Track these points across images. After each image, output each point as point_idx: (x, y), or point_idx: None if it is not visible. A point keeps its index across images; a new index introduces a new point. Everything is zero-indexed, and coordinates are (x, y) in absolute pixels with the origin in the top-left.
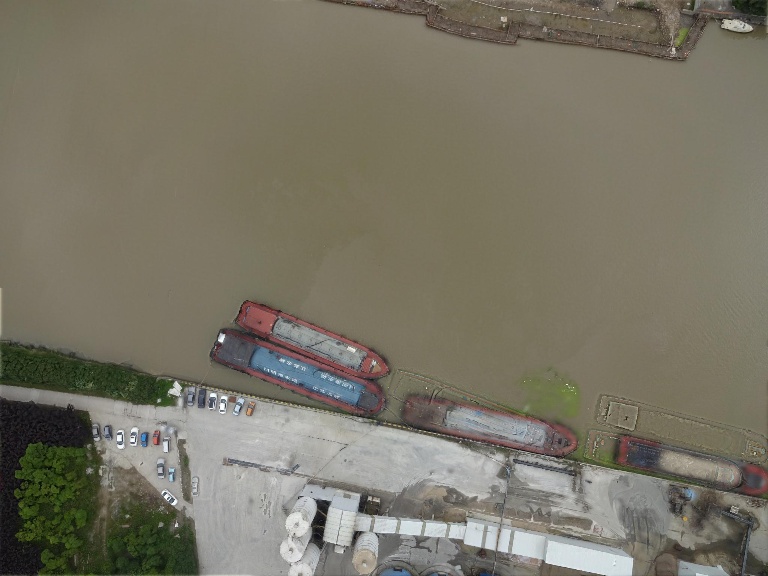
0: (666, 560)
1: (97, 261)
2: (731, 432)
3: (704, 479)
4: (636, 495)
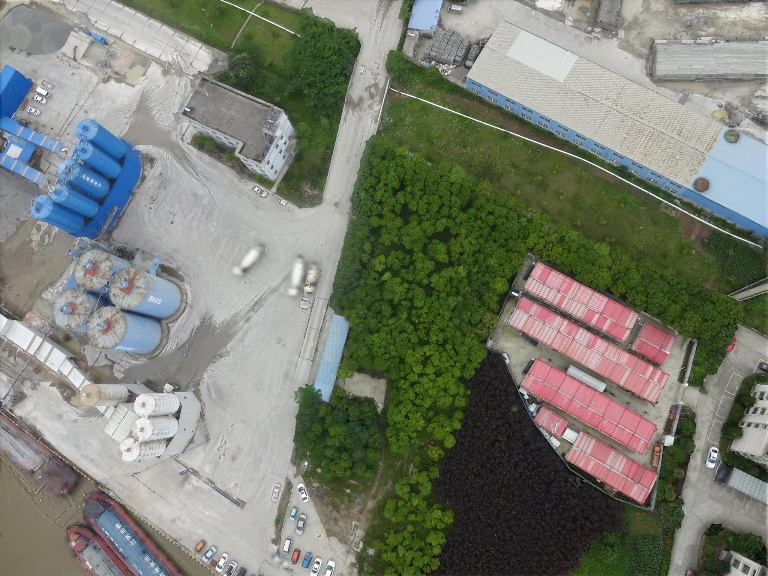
0: None
1: None
2: None
3: None
4: None
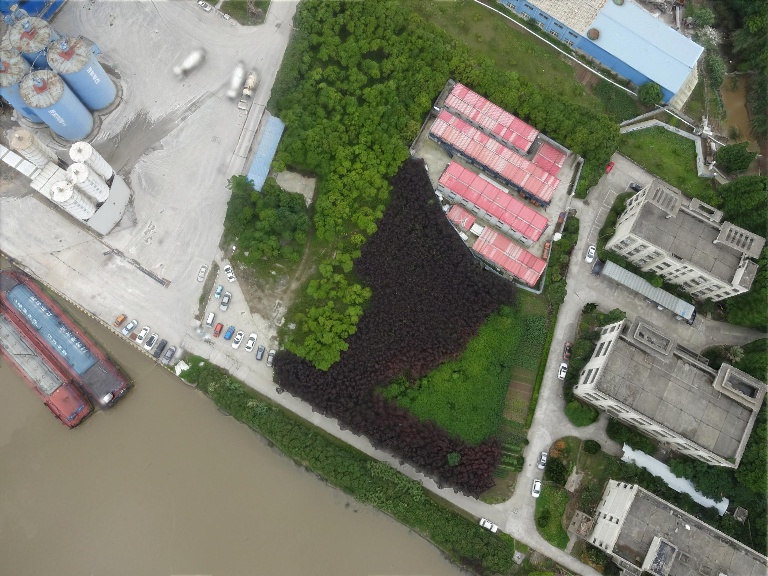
0: None
1: (204, 533)
2: None
3: None
4: None
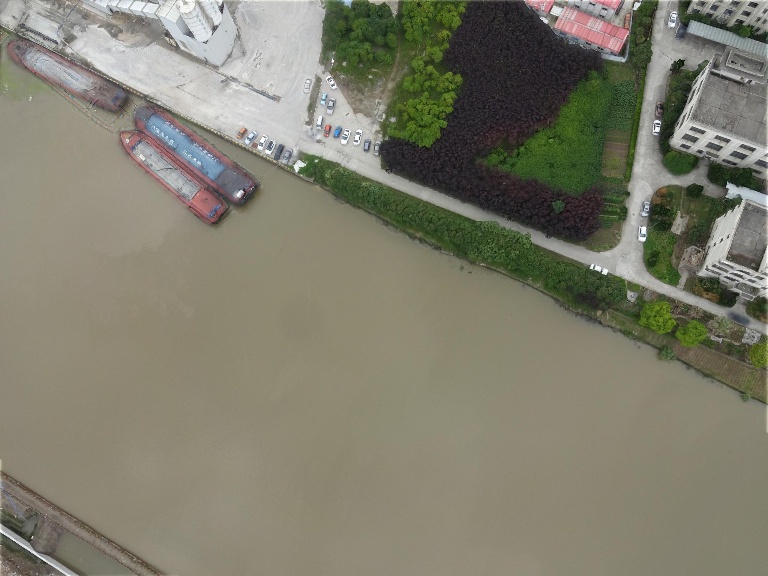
0: None
1: (336, 300)
2: None
3: None
4: None
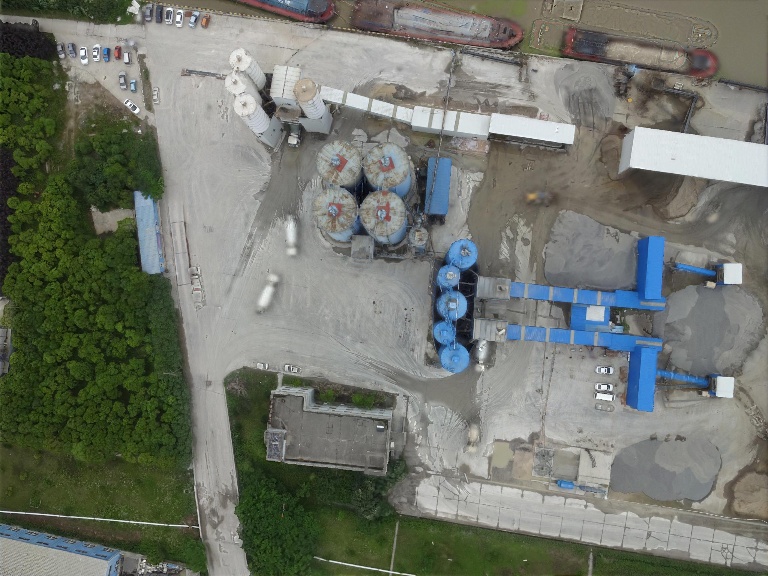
0: (611, 139)
1: None
2: (678, 24)
3: (649, 64)
4: (581, 77)
